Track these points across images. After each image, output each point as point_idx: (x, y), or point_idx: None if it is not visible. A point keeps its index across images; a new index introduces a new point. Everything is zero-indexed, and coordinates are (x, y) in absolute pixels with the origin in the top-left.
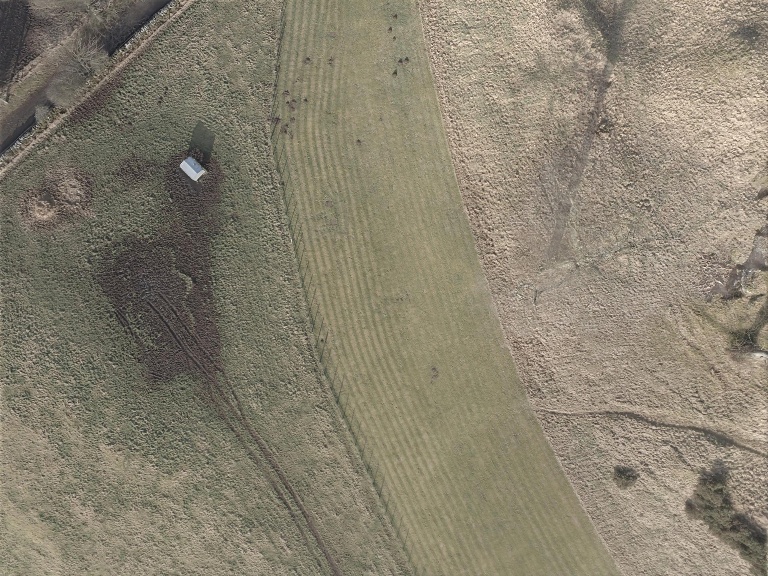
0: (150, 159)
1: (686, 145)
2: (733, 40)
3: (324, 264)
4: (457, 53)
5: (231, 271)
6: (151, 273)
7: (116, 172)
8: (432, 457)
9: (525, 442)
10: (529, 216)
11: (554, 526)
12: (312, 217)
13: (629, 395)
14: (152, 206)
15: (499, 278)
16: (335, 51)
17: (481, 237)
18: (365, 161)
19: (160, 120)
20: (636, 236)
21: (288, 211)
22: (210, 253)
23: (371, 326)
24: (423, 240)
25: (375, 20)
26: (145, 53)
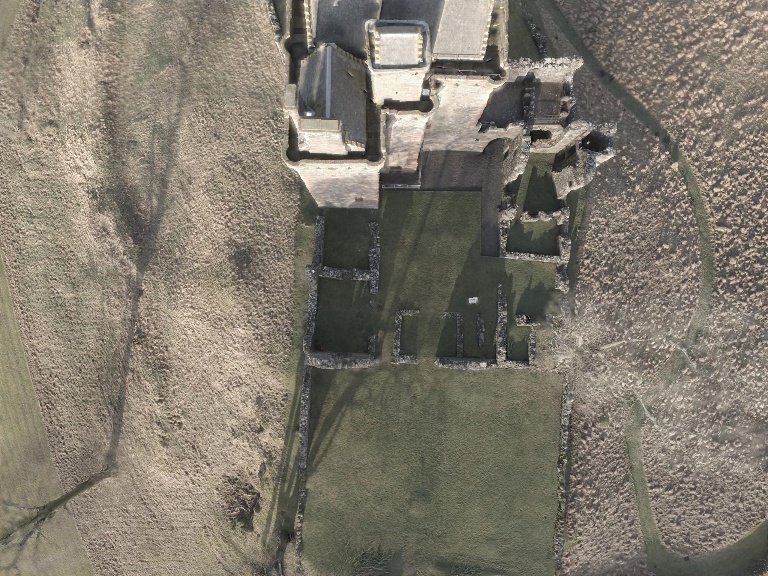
0: None
1: (204, 365)
2: (229, 265)
3: None
4: (25, 242)
5: None
6: None
7: None
8: None
9: None
10: (92, 417)
11: None
12: None
13: None
14: None
15: (71, 477)
16: None
17: (53, 434)
18: None
19: None
20: (169, 453)
21: None
22: None
23: None
24: None
25: None
26: None
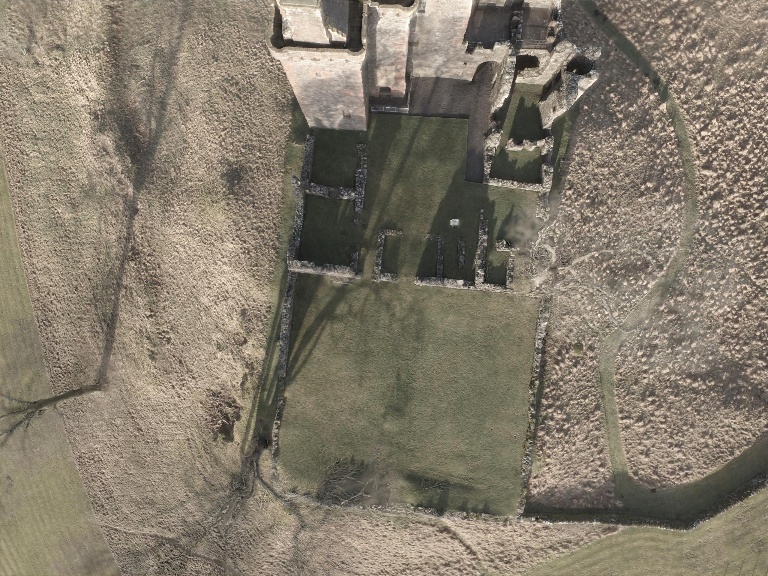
0: None
1: (193, 281)
2: (221, 182)
3: None
4: (29, 163)
5: None
6: None
7: None
8: (10, 564)
9: (93, 556)
10: (86, 333)
11: None
12: None
13: (168, 522)
14: None
15: (64, 392)
16: None
17: (49, 350)
18: None
19: None
20: (157, 367)
21: None
22: None
23: None
24: None
25: None
26: None
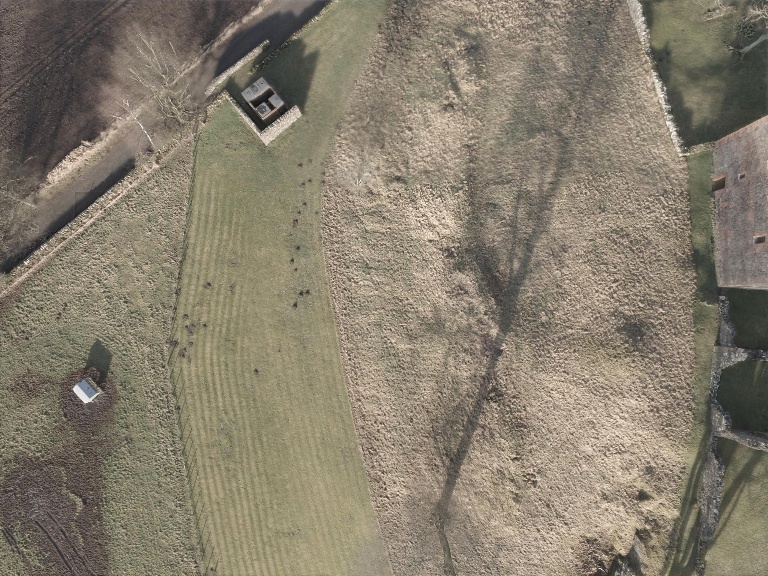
0: (45, 376)
1: (572, 428)
2: (619, 336)
3: (217, 492)
4: (358, 291)
5: (123, 493)
6: (41, 492)
7: (11, 387)
8: None
9: None
10: (421, 466)
11: None
12: (207, 444)
13: None
14: (45, 424)
15: (391, 522)
16: (236, 278)
17: (374, 479)
18: (262, 391)
19: (58, 336)
20: (521, 510)
21: (183, 436)
22: (102, 474)
23: (261, 558)
24: (317, 476)
25: (277, 250)
26: (45, 268)
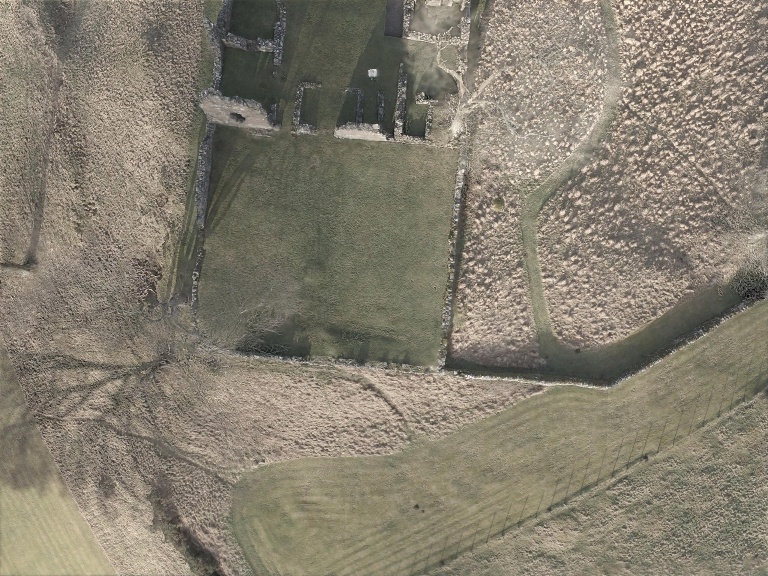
0: None
1: (117, 148)
2: (141, 40)
3: None
4: None
5: None
6: None
7: None
8: None
9: (27, 447)
10: (15, 216)
11: (59, 533)
12: None
13: (99, 402)
14: None
15: None
16: None
17: None
18: None
19: None
20: (84, 240)
21: None
22: None
23: None
24: None
25: None
26: None
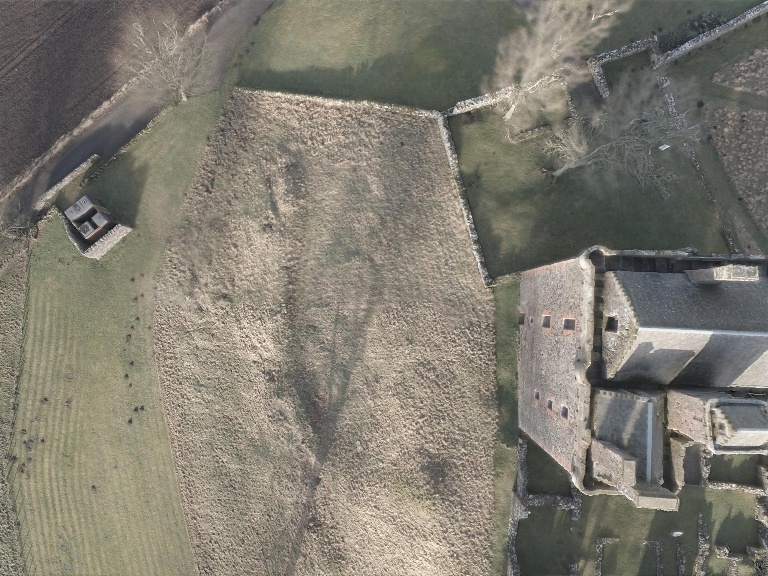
0: None
1: (385, 564)
2: (422, 475)
3: None
4: (191, 407)
5: None
6: None
7: None
8: None
9: None
10: None
11: None
12: (47, 560)
13: None
14: None
15: None
16: (72, 393)
17: None
18: (100, 508)
19: None
20: None
21: (23, 552)
22: None
23: None
24: None
25: (112, 365)
26: None
